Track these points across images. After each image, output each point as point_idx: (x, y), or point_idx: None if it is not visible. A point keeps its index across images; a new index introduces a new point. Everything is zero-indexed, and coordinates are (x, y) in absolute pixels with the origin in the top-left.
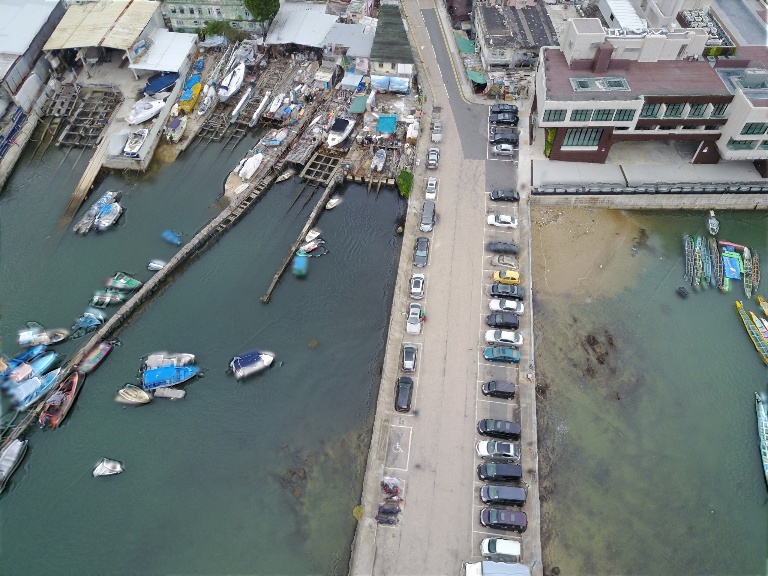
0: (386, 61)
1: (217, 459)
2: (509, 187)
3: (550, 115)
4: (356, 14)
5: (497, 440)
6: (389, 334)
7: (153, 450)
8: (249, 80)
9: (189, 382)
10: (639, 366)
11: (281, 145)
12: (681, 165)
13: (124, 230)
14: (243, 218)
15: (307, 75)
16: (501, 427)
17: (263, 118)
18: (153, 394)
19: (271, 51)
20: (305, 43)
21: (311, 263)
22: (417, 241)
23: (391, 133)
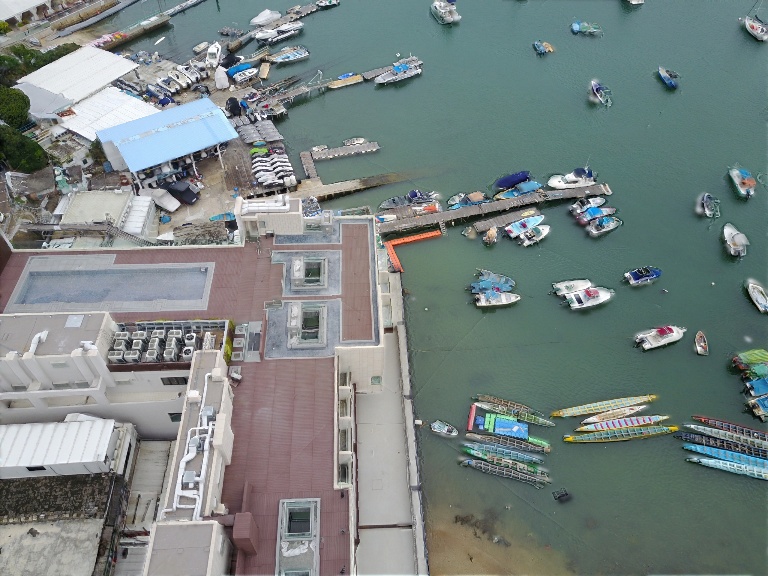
0: None
1: None
2: None
3: None
4: None
5: None
6: None
7: None
8: None
9: None
10: None
11: None
12: None
13: None
14: None
15: None
16: None
17: None
18: None
19: None
20: None
21: None
22: None
23: None
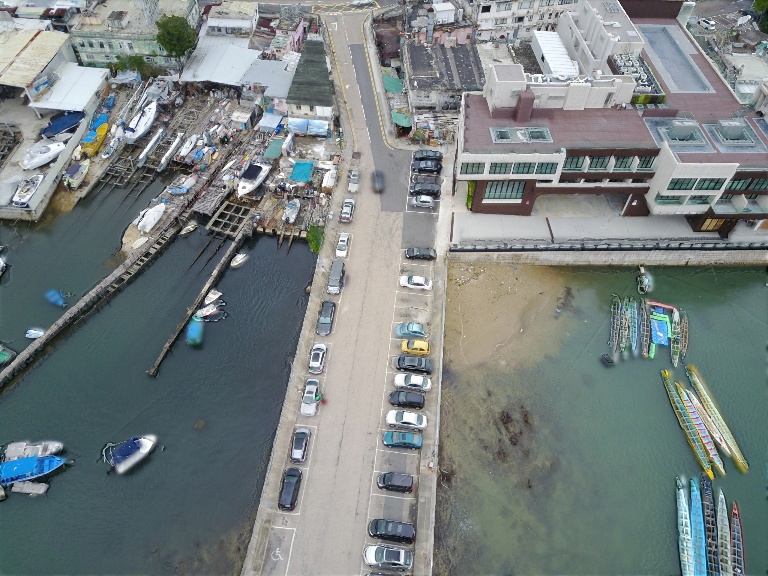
0: (303, 103)
1: (75, 568)
2: (427, 243)
3: (468, 168)
4: (280, 49)
5: (389, 543)
6: (281, 416)
7: (4, 557)
8: (162, 119)
9: (54, 473)
10: (554, 447)
11: (189, 193)
12: (610, 218)
13: (6, 290)
14: (140, 276)
15: (225, 114)
16: (392, 530)
17: (173, 162)
18: (10, 489)
19: (188, 88)
20: (222, 81)
21: (208, 329)
22: (322, 306)
23: (306, 182)
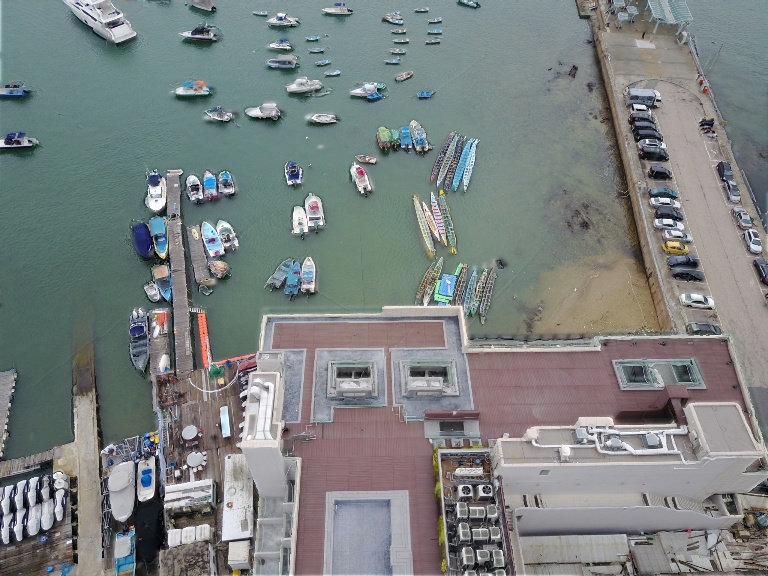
0: None
1: None
2: None
3: None
4: None
5: None
6: None
7: None
8: None
9: None
10: (547, 210)
11: None
12: None
13: None
14: None
15: None
16: (657, 149)
17: None
18: None
19: None
20: None
21: None
22: None
23: None
